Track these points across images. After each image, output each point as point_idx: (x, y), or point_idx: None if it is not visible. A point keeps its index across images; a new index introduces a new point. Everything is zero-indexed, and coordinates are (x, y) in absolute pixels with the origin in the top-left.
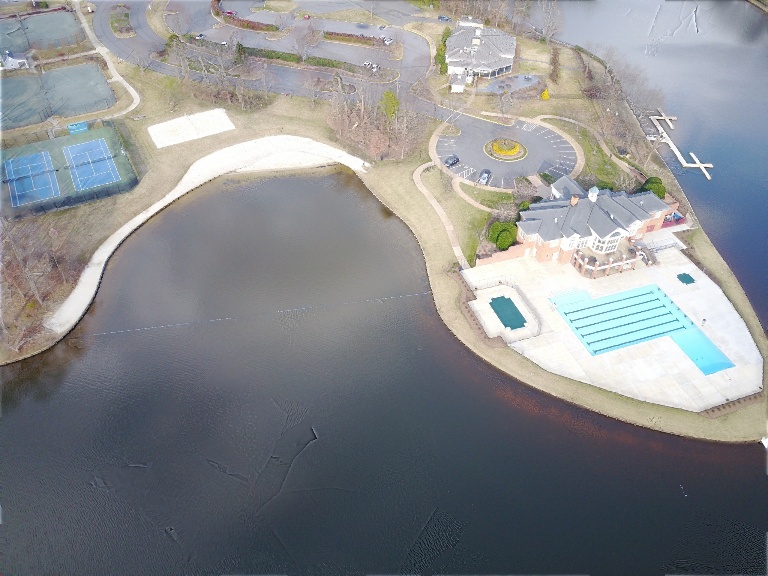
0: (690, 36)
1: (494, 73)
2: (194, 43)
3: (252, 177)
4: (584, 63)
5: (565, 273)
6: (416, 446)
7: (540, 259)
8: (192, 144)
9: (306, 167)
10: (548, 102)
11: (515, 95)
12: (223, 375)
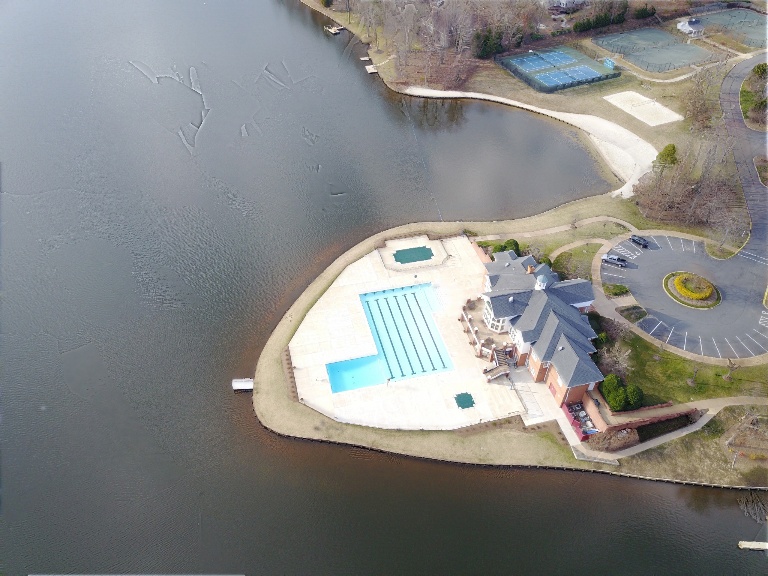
0: None
1: None
2: None
3: (584, 142)
4: None
5: None
6: None
7: None
8: (615, 110)
9: (610, 167)
10: None
11: None
12: (315, 88)
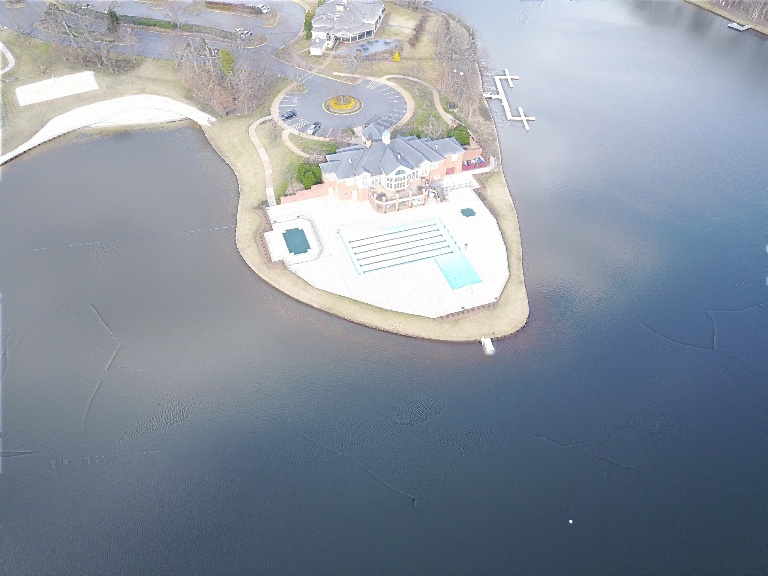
0: (564, 5)
1: (355, 38)
2: (78, 12)
3: (104, 131)
4: (450, 29)
5: (361, 209)
6: (50, 299)
7: (340, 197)
8: (54, 102)
9: (157, 122)
10: (399, 63)
11: (369, 57)
12: None
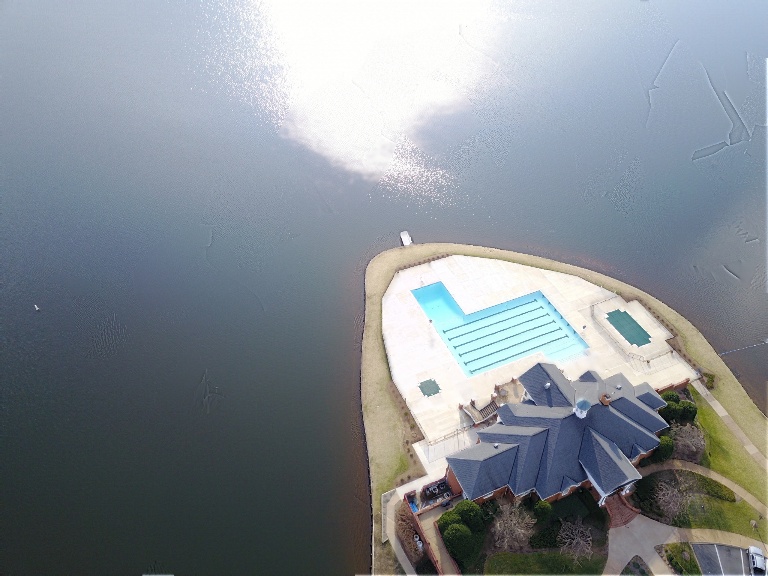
0: None
1: None
2: None
3: None
4: None
5: None
6: (683, 39)
7: None
8: None
9: None
10: None
11: None
12: None
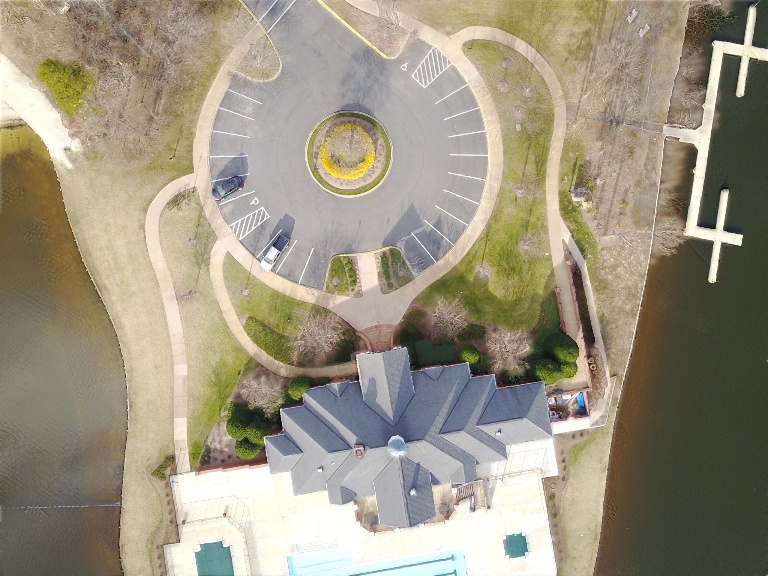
0: None
1: None
2: None
3: None
4: None
5: (334, 506)
6: None
7: None
8: None
9: None
10: None
11: None
12: None
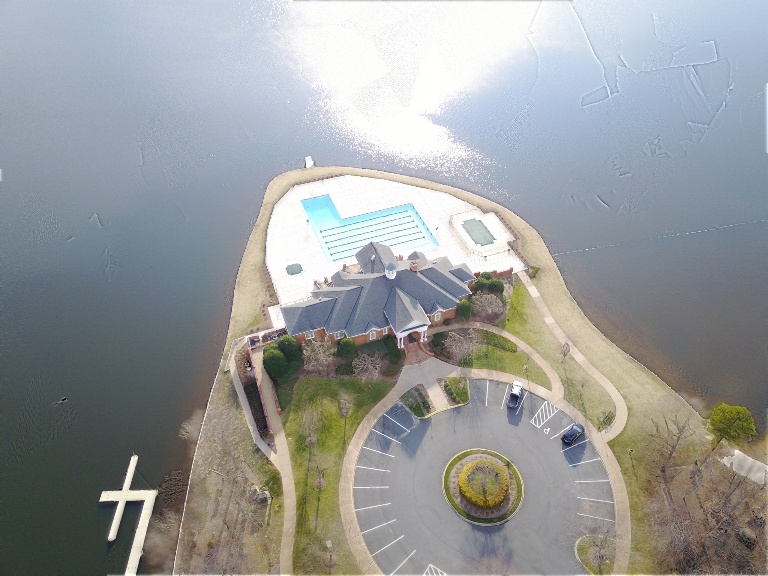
0: None
1: None
2: None
3: None
4: None
5: None
6: None
7: None
8: None
9: None
10: None
11: None
12: None
